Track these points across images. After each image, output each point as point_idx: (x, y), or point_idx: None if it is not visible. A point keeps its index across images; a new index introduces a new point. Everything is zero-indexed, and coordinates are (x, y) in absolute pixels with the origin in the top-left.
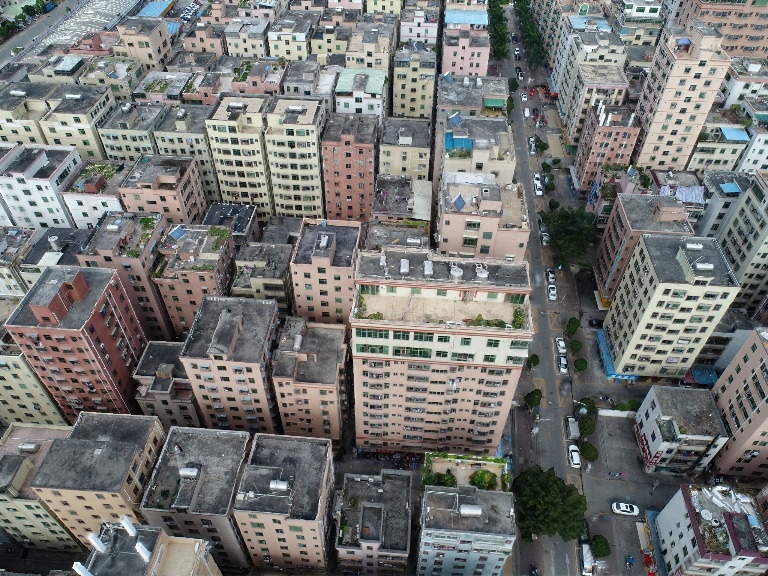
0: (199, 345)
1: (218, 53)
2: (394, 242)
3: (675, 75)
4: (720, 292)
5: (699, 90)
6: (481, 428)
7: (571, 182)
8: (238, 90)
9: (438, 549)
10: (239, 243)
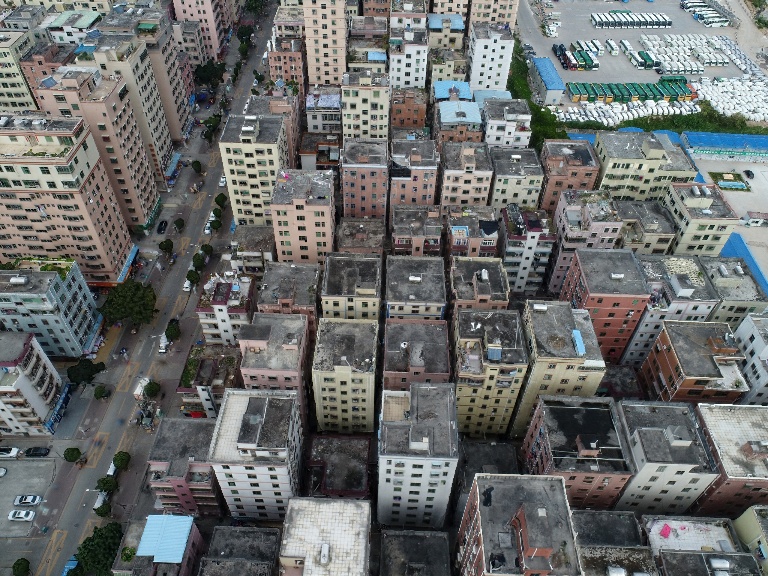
0: None
1: None
2: None
3: (307, 6)
4: (265, 149)
5: (330, 18)
6: (88, 253)
7: None
8: None
9: (7, 314)
10: None
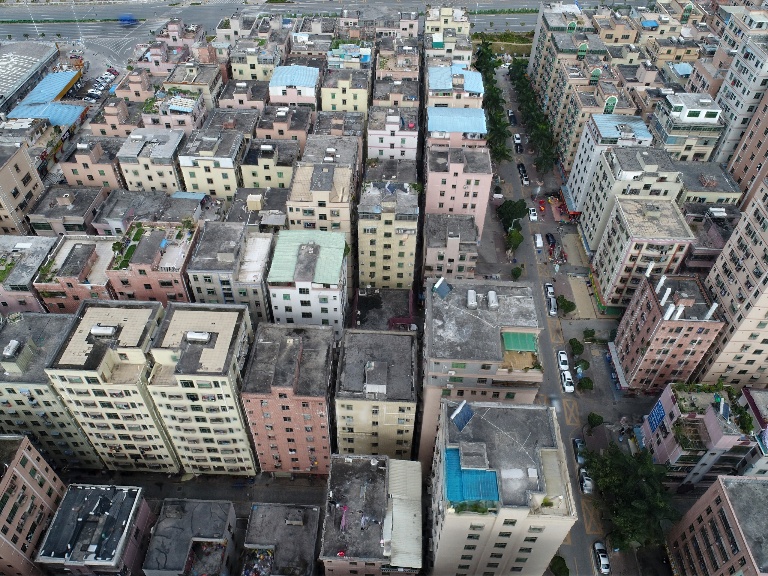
0: None
1: (111, 181)
2: None
3: None
4: None
5: None
6: None
7: (611, 364)
8: (118, 279)
9: None
10: (107, 569)
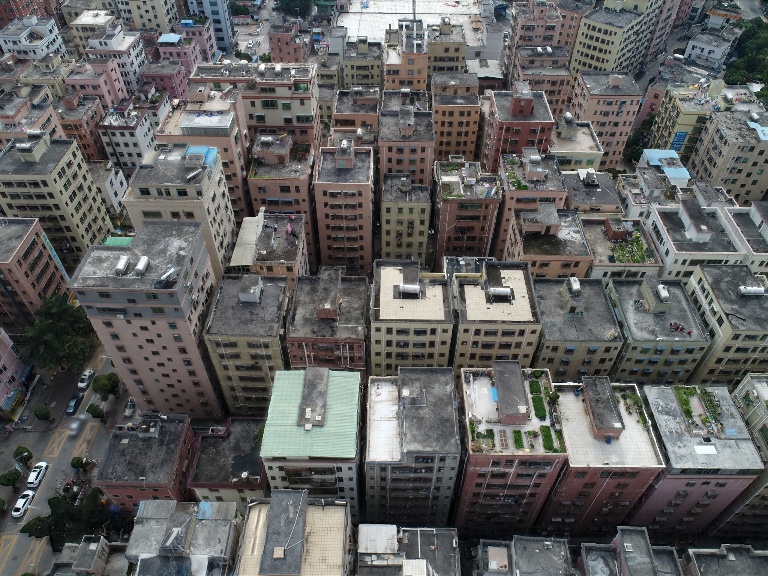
0: (425, 122)
1: None
2: (284, 135)
3: None
4: None
5: None
6: None
7: None
8: None
9: None
10: None
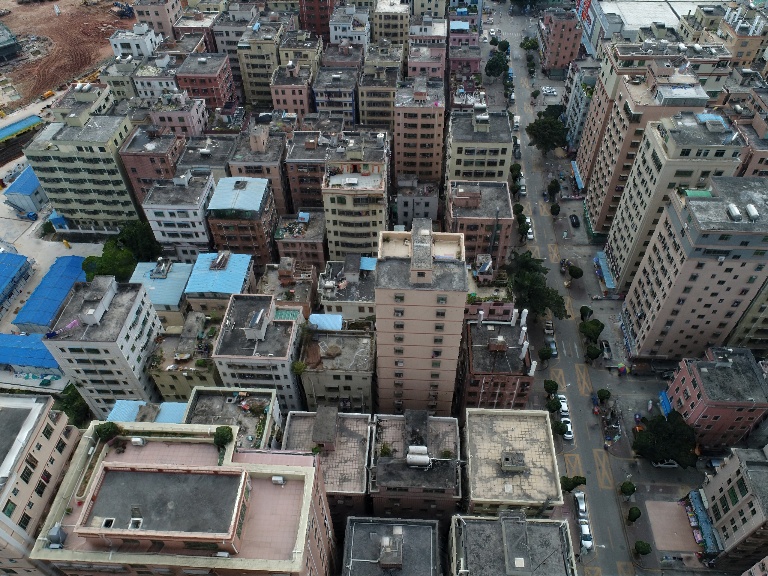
0: None
1: None
2: (716, 107)
3: None
4: None
5: None
6: None
7: None
8: None
9: None
10: None
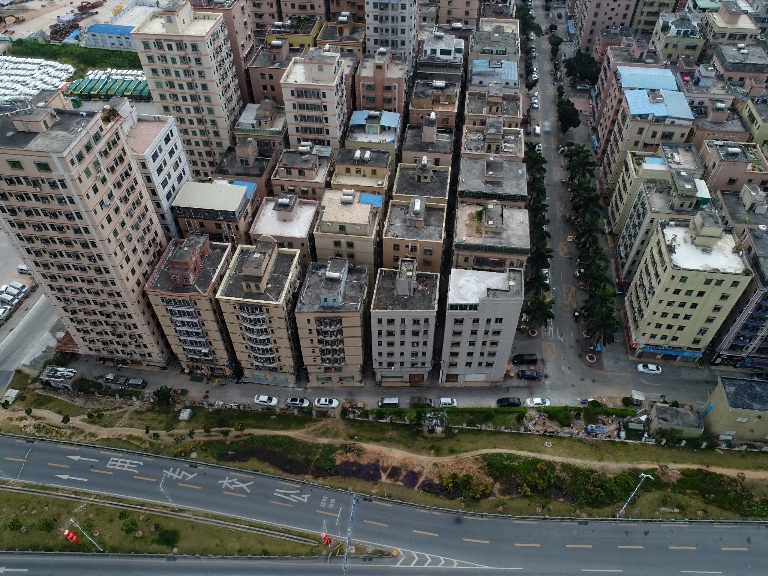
0: None
1: None
2: None
3: None
4: None
5: None
6: None
7: None
8: None
9: None
10: None
